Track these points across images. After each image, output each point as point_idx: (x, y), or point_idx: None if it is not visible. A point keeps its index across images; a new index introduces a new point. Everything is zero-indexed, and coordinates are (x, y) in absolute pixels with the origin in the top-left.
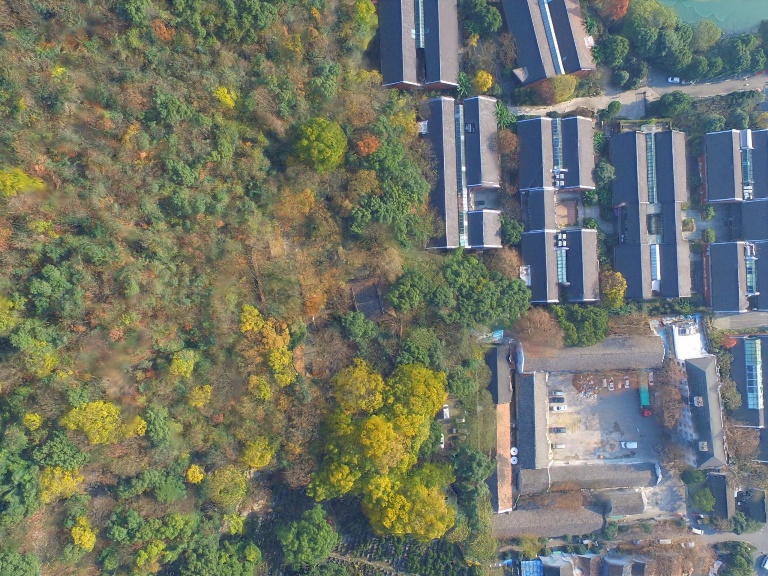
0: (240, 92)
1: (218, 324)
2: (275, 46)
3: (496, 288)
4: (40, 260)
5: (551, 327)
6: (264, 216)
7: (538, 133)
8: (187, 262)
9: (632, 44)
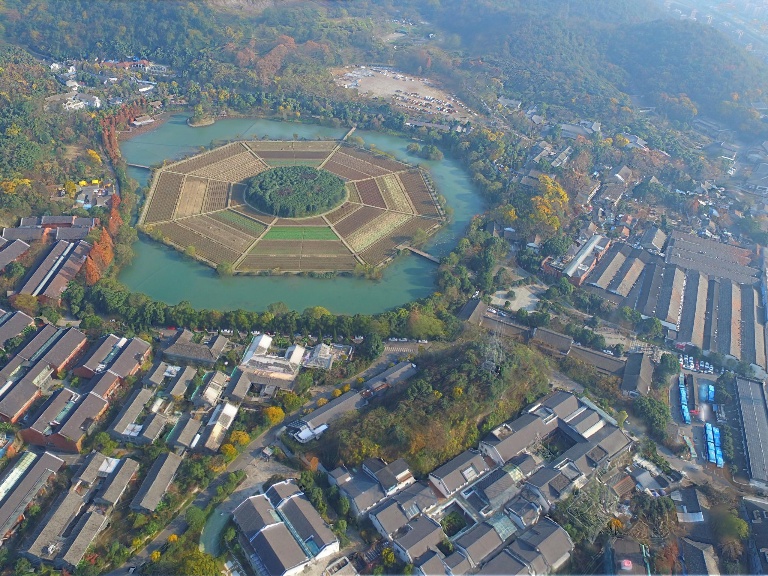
0: None
1: None
2: None
3: None
4: None
5: None
6: None
7: None
8: None
9: (87, 293)
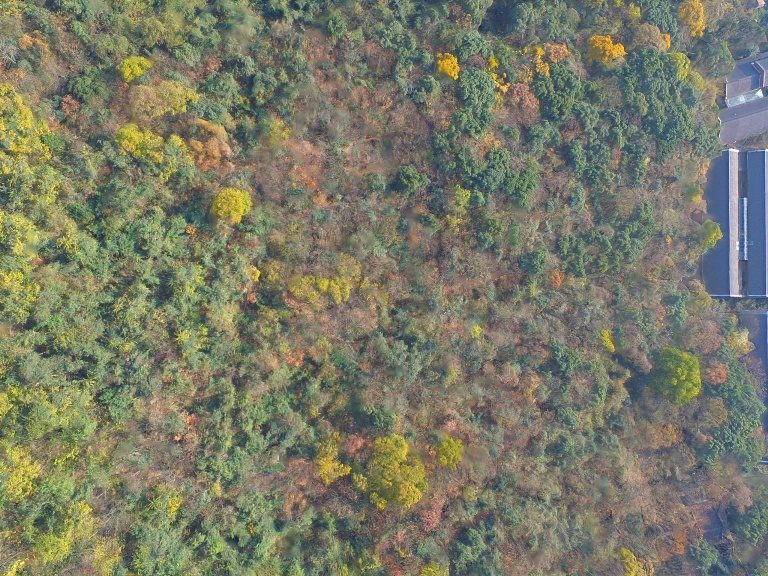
0: (611, 329)
1: (598, 569)
2: (629, 273)
3: None
4: (462, 523)
5: None
6: (629, 451)
7: None
8: (565, 503)
9: None
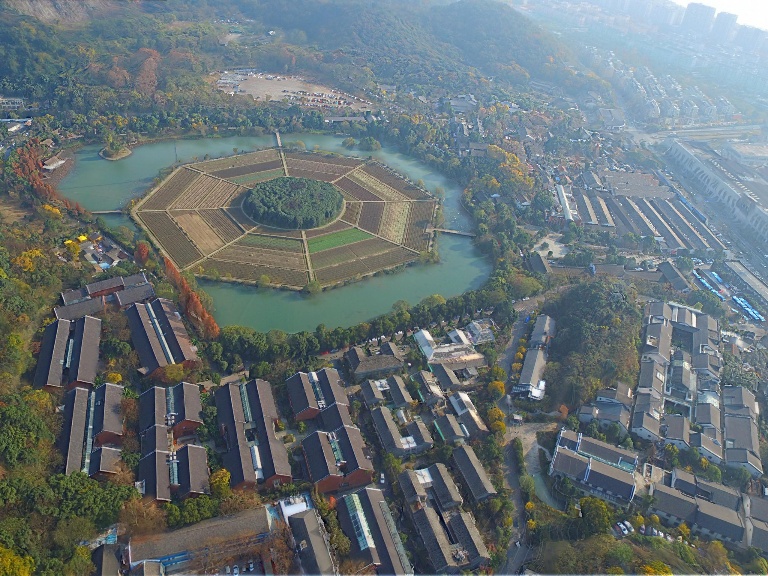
0: None
1: None
2: None
3: None
4: None
5: (156, 514)
6: None
7: (152, 396)
8: None
9: (225, 346)
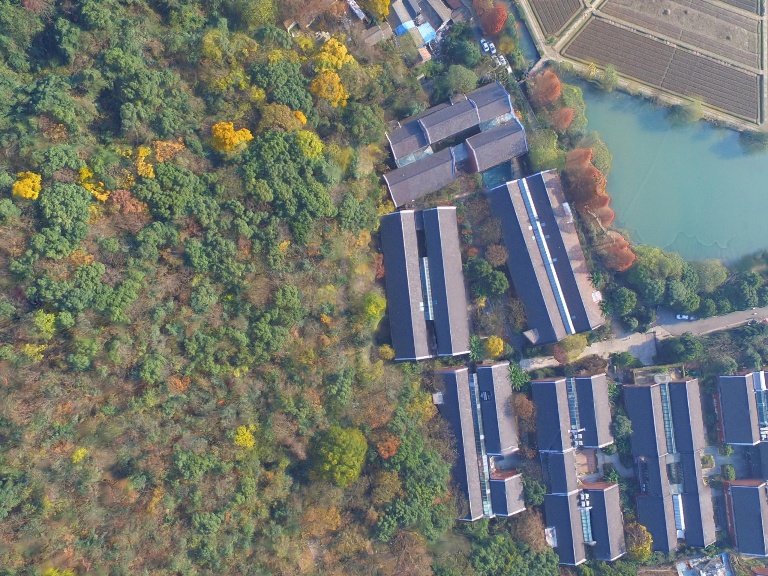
0: (258, 422)
1: None
2: (288, 356)
3: (524, 562)
4: None
5: None
6: (292, 541)
7: (553, 397)
8: None
9: (640, 295)
